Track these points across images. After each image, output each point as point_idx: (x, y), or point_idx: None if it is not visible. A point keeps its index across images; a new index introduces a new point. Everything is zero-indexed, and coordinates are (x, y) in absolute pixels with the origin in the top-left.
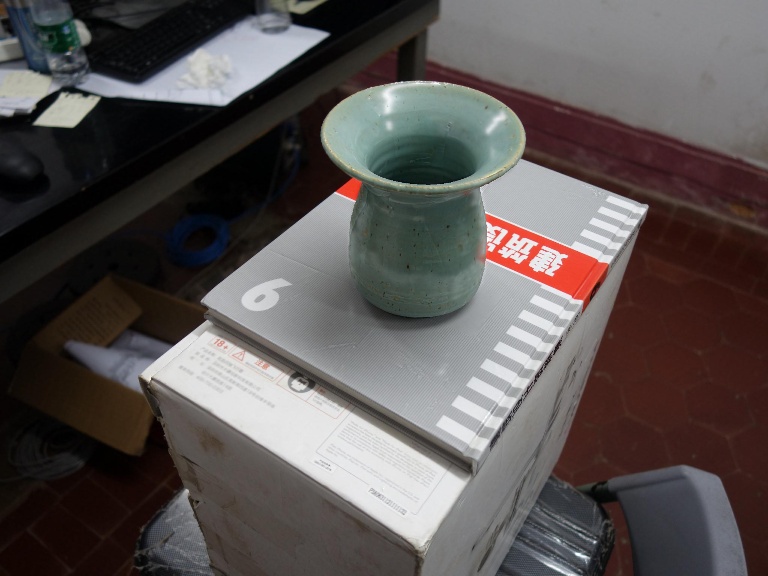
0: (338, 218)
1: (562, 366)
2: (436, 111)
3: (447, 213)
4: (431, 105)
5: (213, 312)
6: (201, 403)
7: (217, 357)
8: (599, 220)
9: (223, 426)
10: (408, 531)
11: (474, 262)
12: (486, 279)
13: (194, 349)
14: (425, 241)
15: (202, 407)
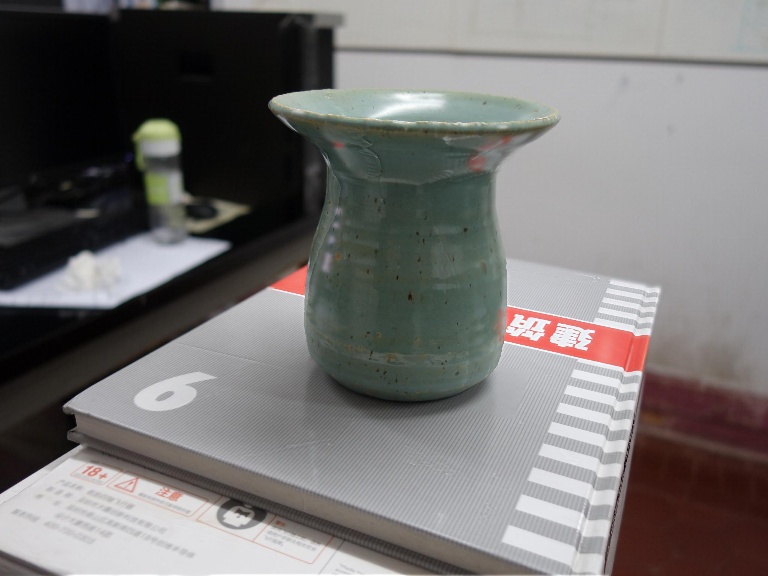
0: (276, 309)
1: (626, 480)
2: (417, 116)
3: (464, 206)
4: (409, 110)
5: (84, 426)
6: (49, 564)
7: (86, 491)
8: (612, 299)
9: None
10: None
11: (500, 299)
12: (500, 357)
13: (44, 484)
14: (434, 252)
15: (50, 571)
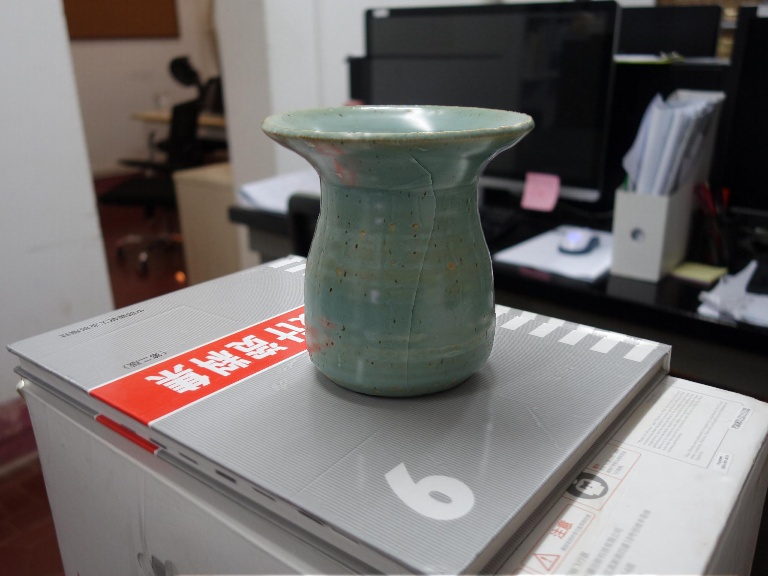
0: (230, 420)
1: None
2: None
3: None
4: None
5: None
6: None
7: None
8: None
9: (711, 575)
10: (767, 409)
11: None
12: None
13: None
14: None
15: None
